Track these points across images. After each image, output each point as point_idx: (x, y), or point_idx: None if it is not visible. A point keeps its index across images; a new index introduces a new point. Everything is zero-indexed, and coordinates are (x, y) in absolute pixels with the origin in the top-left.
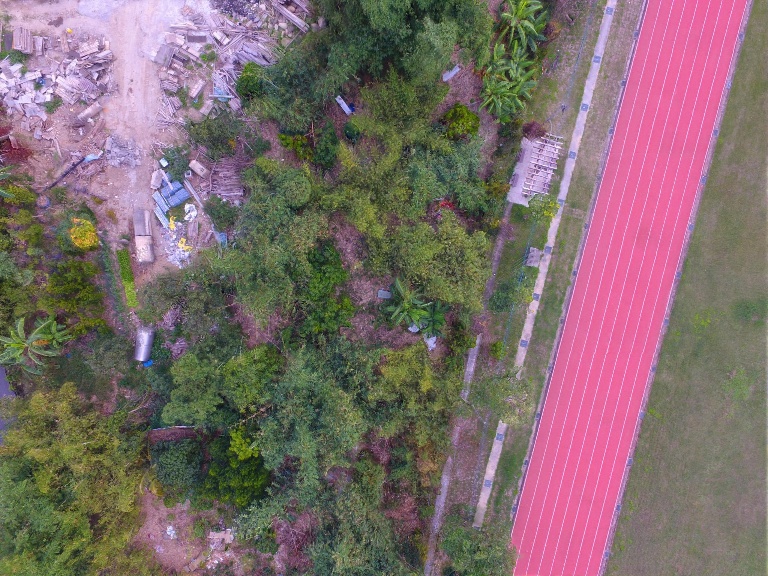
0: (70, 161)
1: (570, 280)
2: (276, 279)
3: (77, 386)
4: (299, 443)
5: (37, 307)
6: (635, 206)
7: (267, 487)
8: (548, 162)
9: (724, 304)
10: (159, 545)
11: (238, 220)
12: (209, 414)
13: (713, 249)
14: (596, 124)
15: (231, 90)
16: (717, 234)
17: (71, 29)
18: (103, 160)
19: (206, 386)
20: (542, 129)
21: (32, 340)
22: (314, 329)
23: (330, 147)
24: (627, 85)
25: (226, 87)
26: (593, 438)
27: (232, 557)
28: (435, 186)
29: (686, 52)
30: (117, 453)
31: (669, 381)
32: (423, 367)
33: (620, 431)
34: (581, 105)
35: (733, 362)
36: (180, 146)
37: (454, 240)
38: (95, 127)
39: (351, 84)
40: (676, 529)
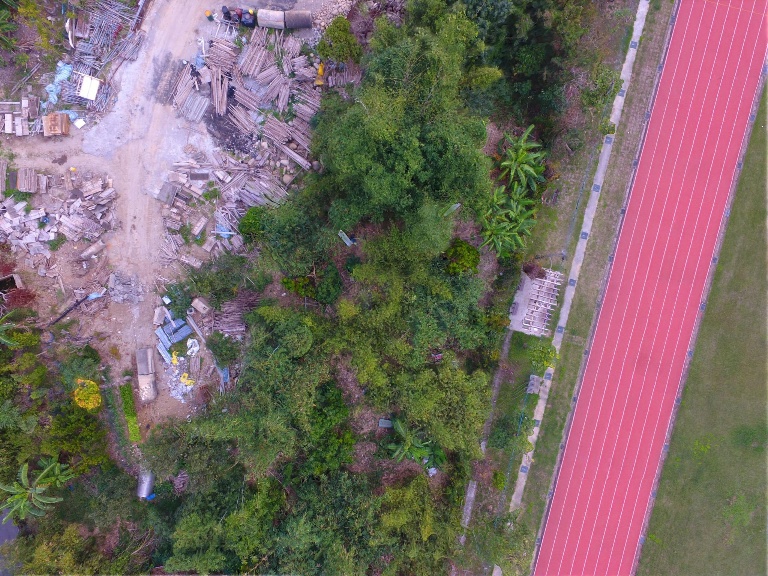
0: (74, 298)
1: (570, 406)
2: (278, 432)
3: (80, 519)
4: None
5: (41, 451)
6: (635, 333)
7: None
8: (548, 298)
9: (724, 430)
10: None
11: (240, 355)
12: None
13: (712, 375)
14: (596, 252)
15: (233, 227)
16: (716, 360)
17: (75, 167)
18: (106, 297)
19: (208, 540)
20: (542, 271)
21: (36, 486)
22: (316, 472)
23: (331, 290)
24: (626, 213)
25: (228, 225)
26: (593, 563)
27: None
28: (436, 335)
29: (685, 181)
30: None
31: (669, 506)
32: (424, 506)
33: (620, 556)
34: (581, 233)
35: (733, 488)
36: (183, 282)
37: (455, 384)
38: (98, 265)
39: None
40: None
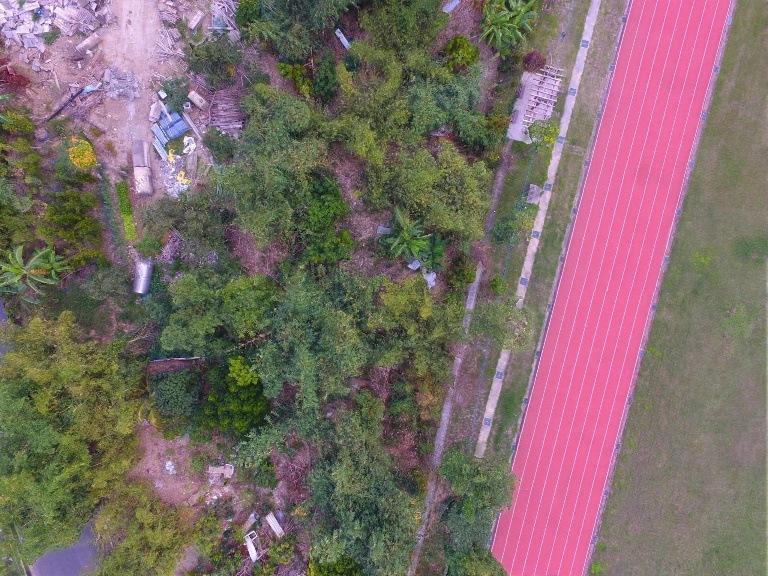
0: (68, 93)
1: (570, 218)
2: (275, 203)
3: (76, 320)
4: (298, 366)
5: (35, 235)
6: (635, 143)
7: (266, 415)
8: (548, 94)
9: (724, 242)
10: (158, 480)
11: None
12: (208, 341)
13: (713, 186)
14: (596, 61)
15: (230, 22)
16: (717, 171)
17: None
18: (102, 92)
19: (205, 309)
20: (542, 59)
21: (30, 267)
22: (313, 258)
23: (329, 76)
24: (627, 21)
25: (225, 18)
26: (593, 376)
27: (231, 493)
28: (435, 112)
29: None
30: (116, 377)
31: (669, 319)
32: (423, 298)
33: (620, 369)
34: (581, 41)
35: (733, 300)
36: (179, 78)
37: (454, 168)
38: (93, 58)
39: (351, 17)
40: (676, 467)
